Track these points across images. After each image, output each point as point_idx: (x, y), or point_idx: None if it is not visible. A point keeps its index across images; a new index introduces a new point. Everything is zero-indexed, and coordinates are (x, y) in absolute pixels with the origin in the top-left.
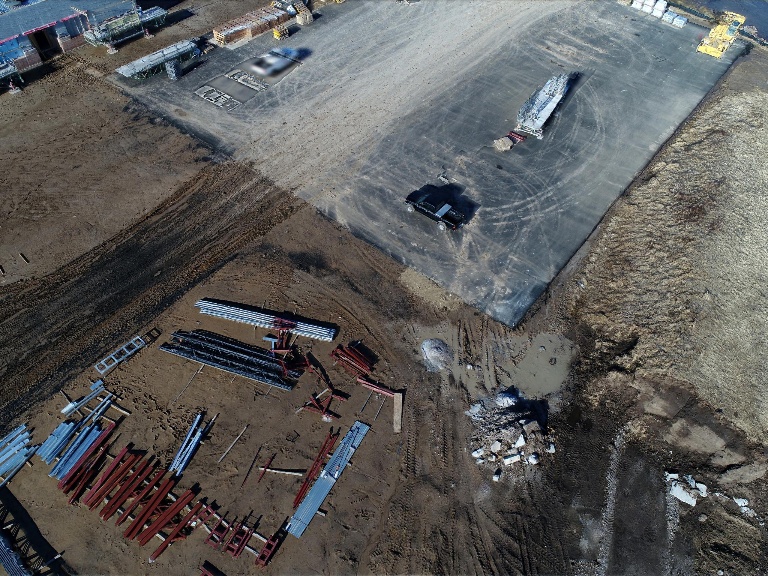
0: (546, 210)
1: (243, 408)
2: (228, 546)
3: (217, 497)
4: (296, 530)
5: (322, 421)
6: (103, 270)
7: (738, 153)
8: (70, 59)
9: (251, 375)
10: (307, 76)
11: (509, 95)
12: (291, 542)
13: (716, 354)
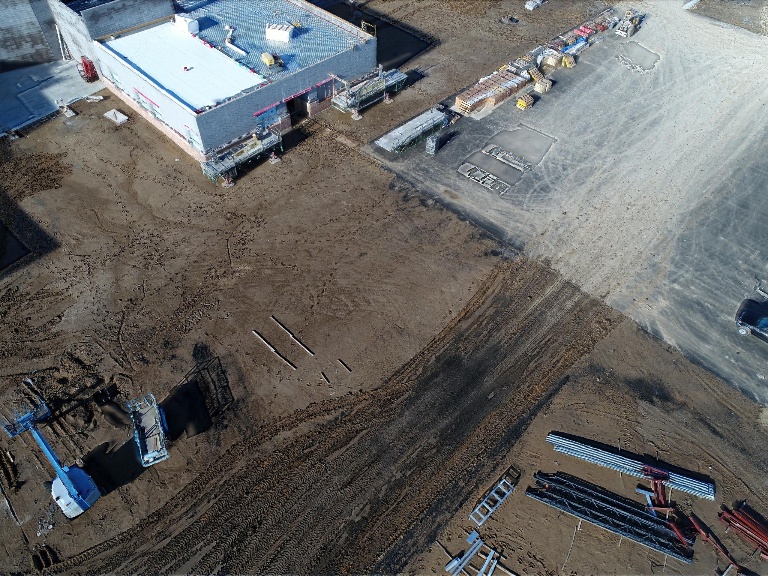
0: None
1: None
2: None
3: None
4: None
5: None
6: (432, 386)
7: None
8: (317, 124)
9: (641, 540)
10: (568, 155)
11: None
12: None
13: None
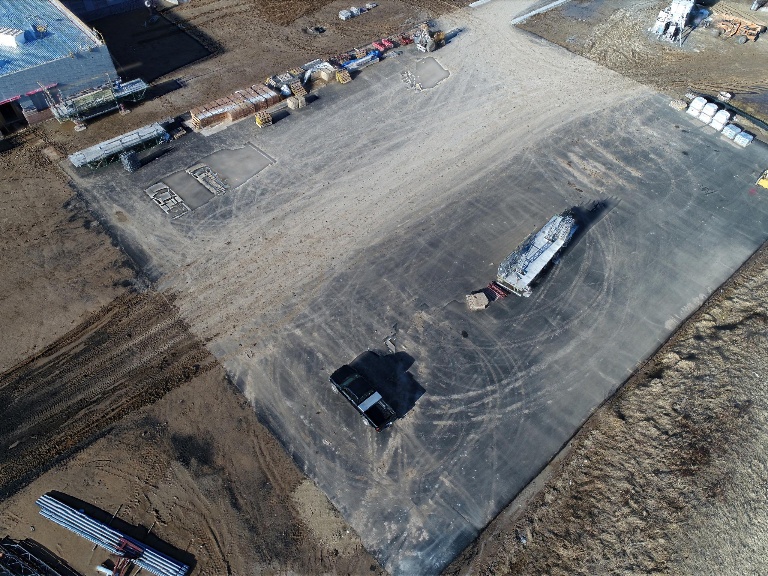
0: (507, 409)
1: None
2: None
3: None
4: None
5: None
6: None
7: None
8: (33, 134)
9: None
10: (276, 179)
11: (504, 227)
12: None
13: None
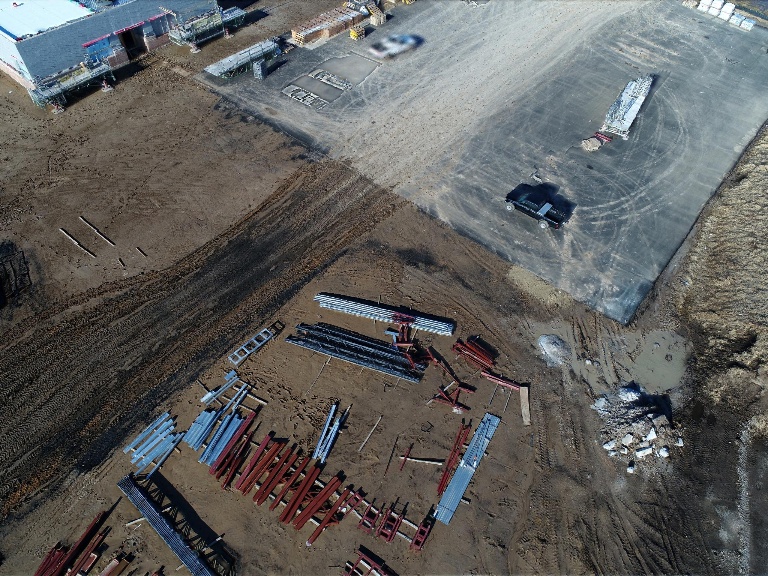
0: (641, 210)
1: (375, 399)
2: (381, 531)
3: (363, 484)
4: (444, 517)
5: (453, 413)
6: (219, 264)
7: None
8: (155, 58)
9: (379, 367)
10: (389, 76)
11: (589, 96)
12: (440, 528)
13: None
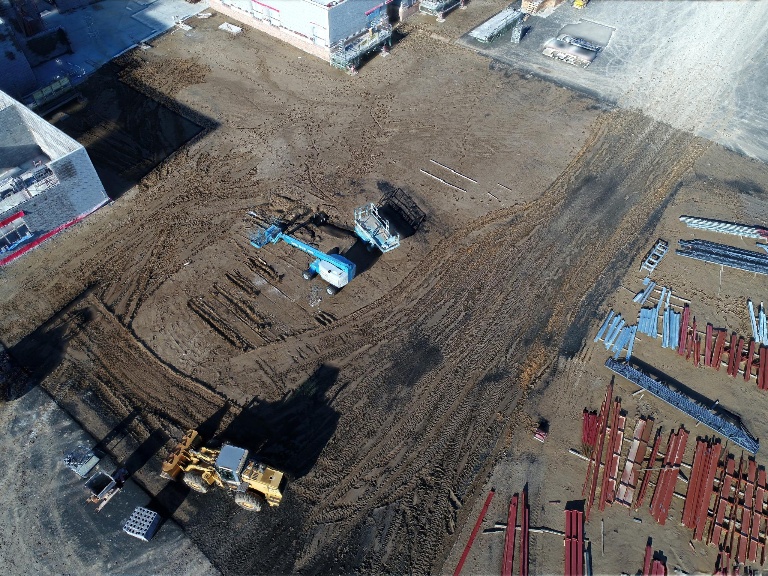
0: None
1: None
2: None
3: None
4: None
5: None
6: (579, 195)
7: None
8: (410, 27)
9: None
10: (628, 39)
11: None
12: None
13: None
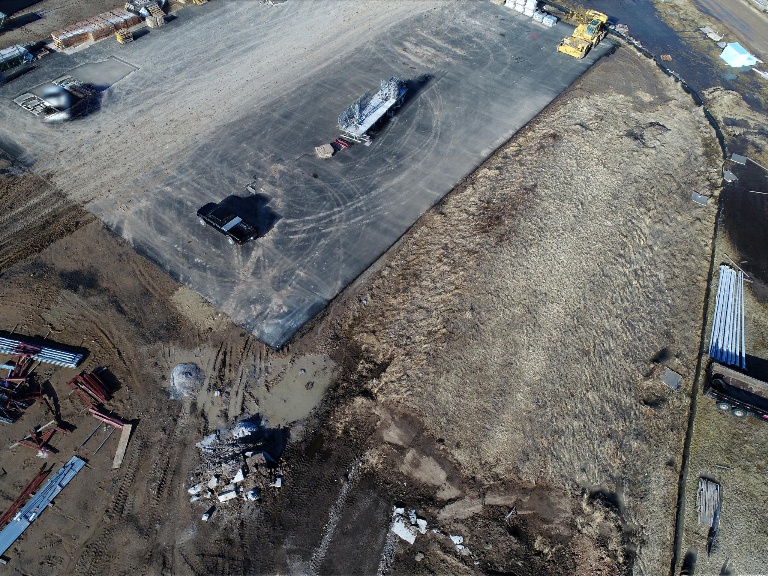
0: (351, 221)
1: None
2: None
3: None
4: None
5: (36, 457)
6: None
7: (561, 158)
8: None
9: None
10: (140, 82)
11: (348, 99)
12: None
13: (458, 378)
